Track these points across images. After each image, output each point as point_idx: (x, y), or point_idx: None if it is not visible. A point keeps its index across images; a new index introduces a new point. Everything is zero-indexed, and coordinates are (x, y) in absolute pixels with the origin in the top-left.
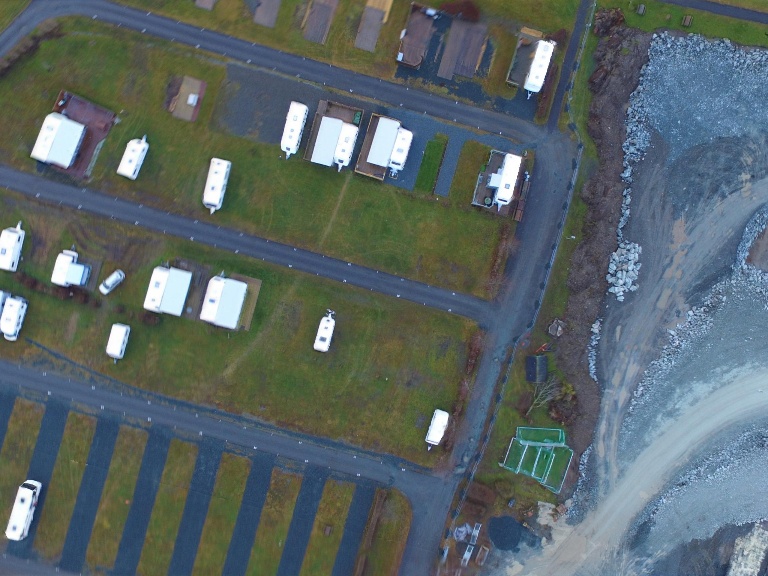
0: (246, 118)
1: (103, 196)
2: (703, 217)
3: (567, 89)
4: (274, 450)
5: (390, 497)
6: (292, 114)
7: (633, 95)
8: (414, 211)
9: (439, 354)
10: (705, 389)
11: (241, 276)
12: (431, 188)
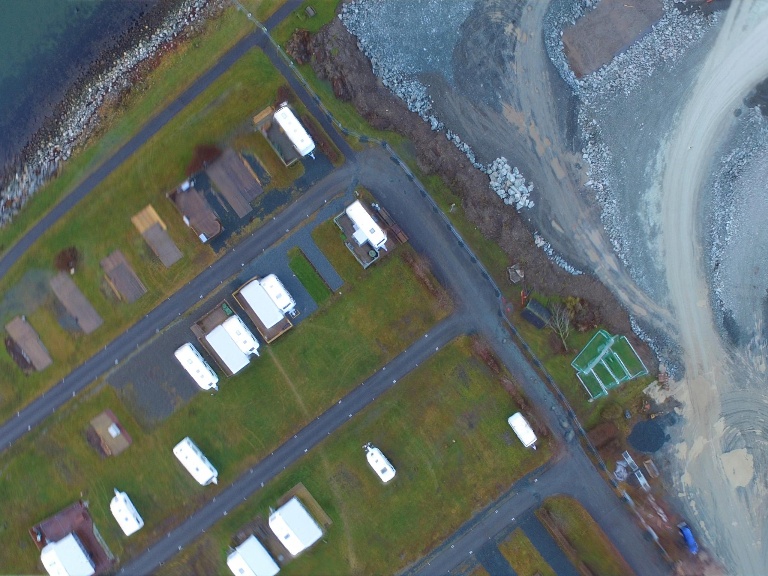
0: (161, 398)
1: (139, 559)
2: (516, 88)
3: (330, 121)
4: (443, 572)
5: (550, 508)
6: (185, 362)
7: (375, 70)
8: (336, 319)
9: (466, 384)
10: (655, 192)
11: (285, 496)
12: (328, 291)
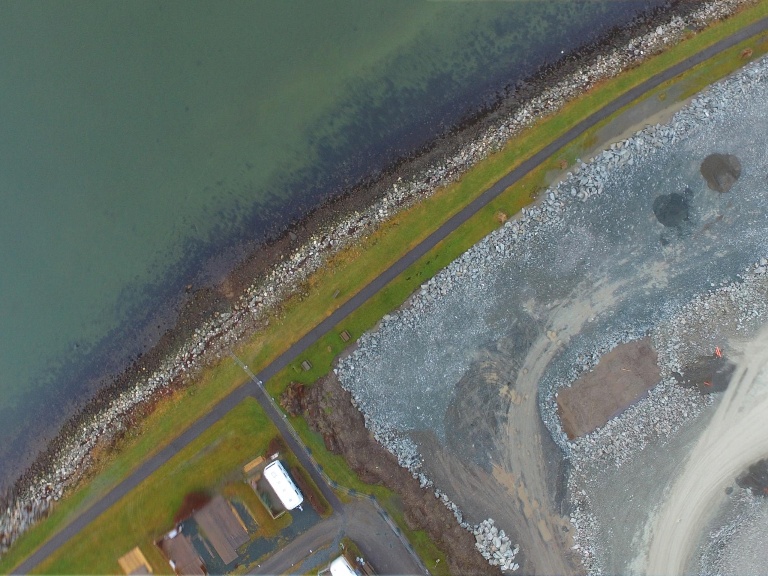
0: None
1: None
2: (507, 449)
3: (320, 475)
4: None
5: None
6: None
7: (367, 425)
8: None
9: None
10: (641, 561)
11: None
12: None
